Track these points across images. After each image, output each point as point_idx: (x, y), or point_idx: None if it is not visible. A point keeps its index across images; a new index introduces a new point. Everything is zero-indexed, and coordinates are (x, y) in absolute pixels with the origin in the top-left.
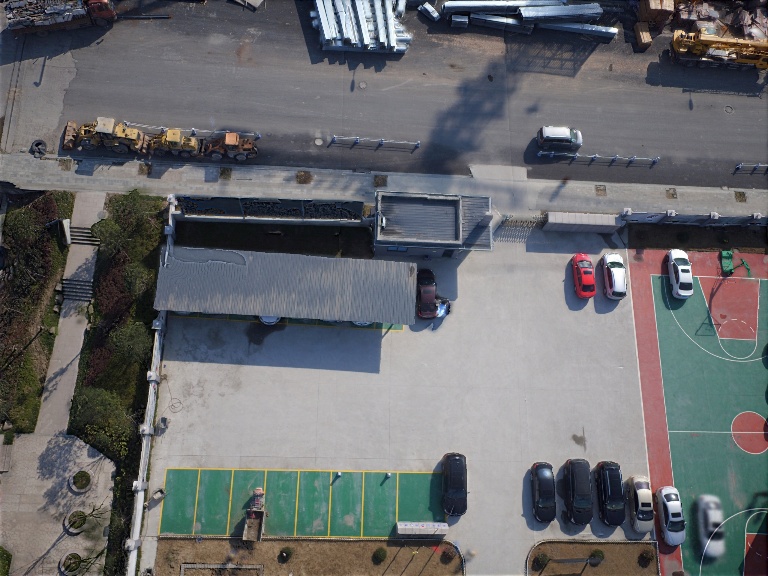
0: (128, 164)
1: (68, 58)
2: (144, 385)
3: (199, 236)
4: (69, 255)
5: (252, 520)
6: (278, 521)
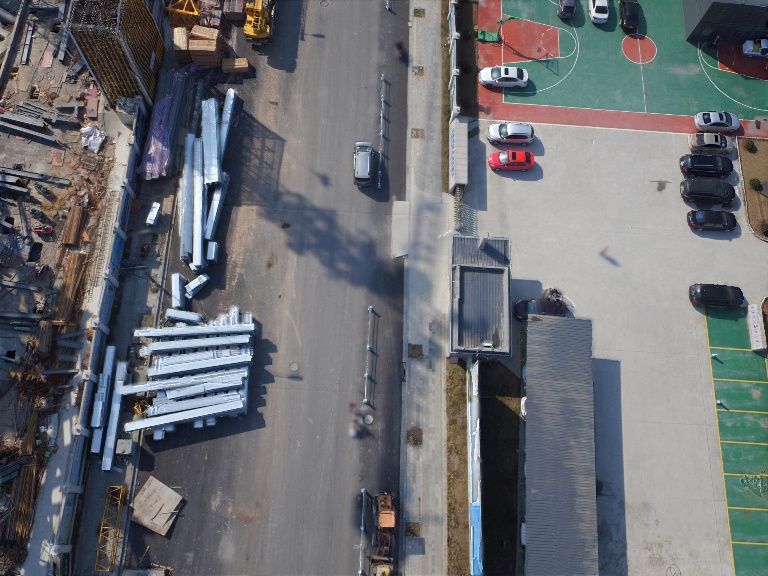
0: None
1: None
2: None
3: (488, 558)
4: None
5: None
6: (767, 461)
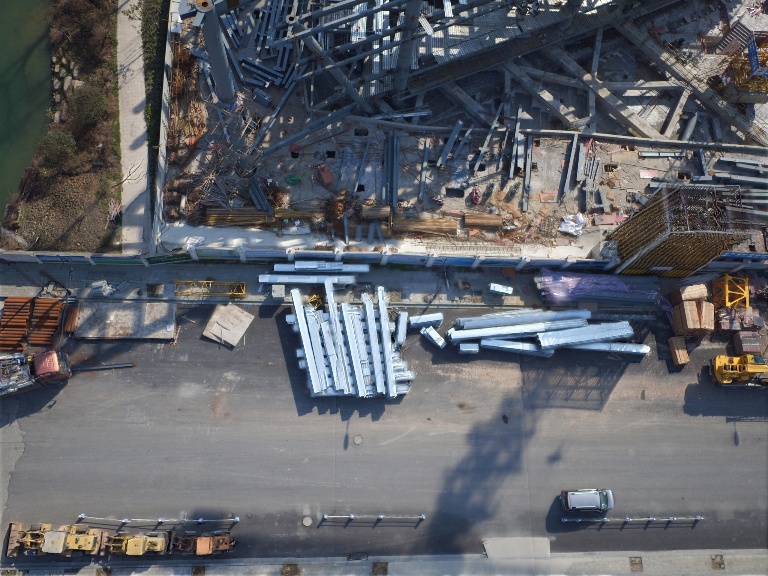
0: (83, 571)
1: (14, 430)
2: None
3: None
4: None
5: None
6: None
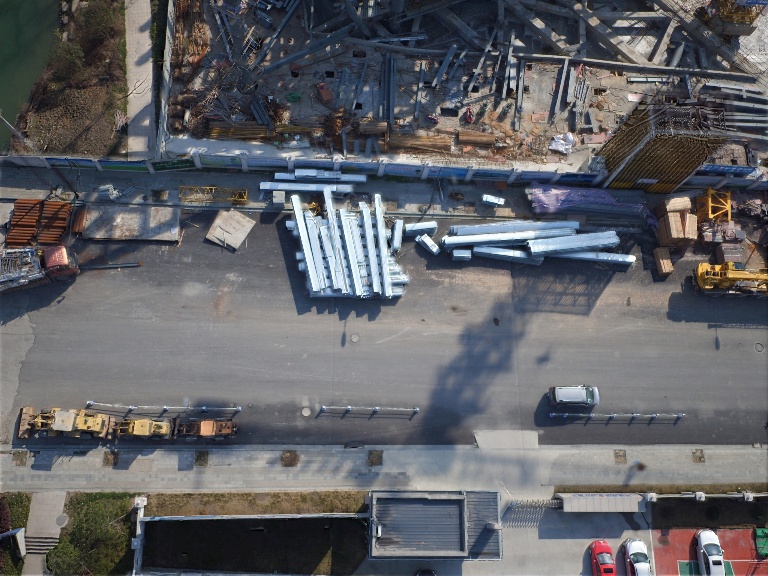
0: (91, 453)
1: (25, 322)
2: None
3: (171, 537)
4: (24, 568)
5: None
6: None
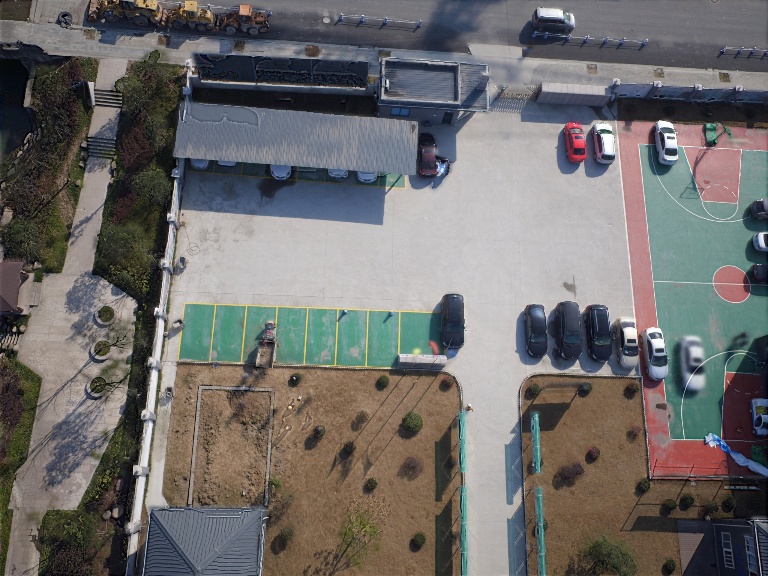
0: (148, 35)
1: None
2: (164, 231)
3: (214, 101)
4: (93, 116)
5: (264, 350)
6: (288, 351)
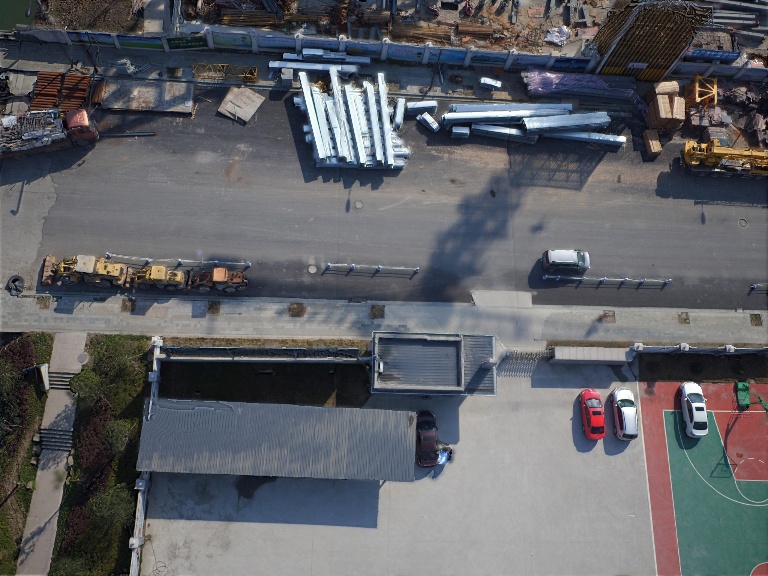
0: (110, 300)
1: (47, 182)
2: (127, 547)
3: (186, 378)
4: (47, 402)
5: None
6: None
